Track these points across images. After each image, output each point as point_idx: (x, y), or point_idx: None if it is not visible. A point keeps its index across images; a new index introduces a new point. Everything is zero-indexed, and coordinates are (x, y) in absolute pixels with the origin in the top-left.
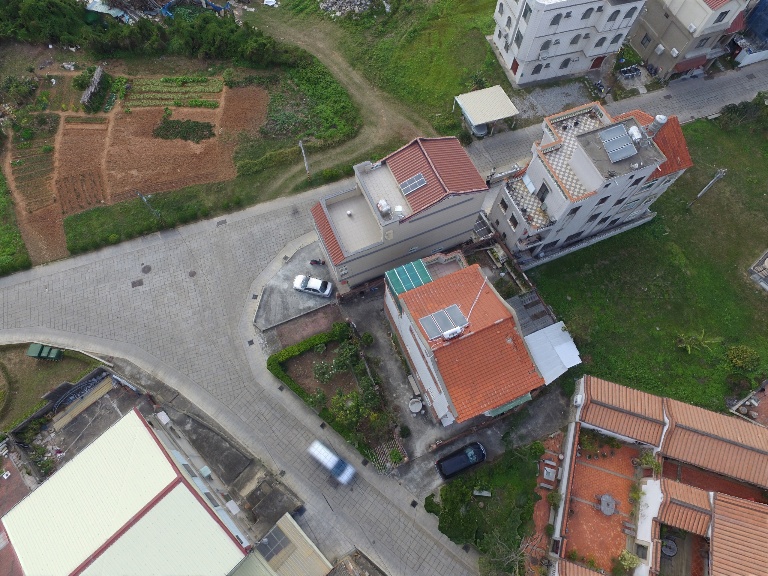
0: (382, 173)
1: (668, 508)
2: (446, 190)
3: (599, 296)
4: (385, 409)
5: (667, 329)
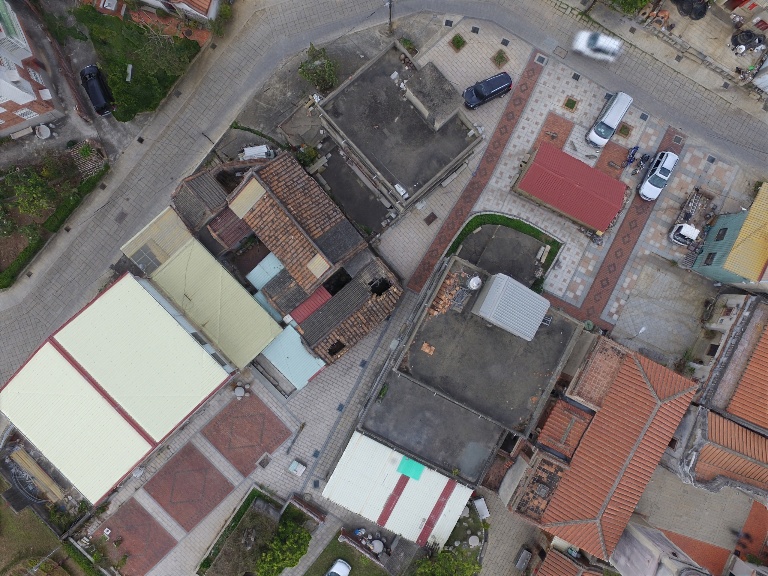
0: None
1: None
2: None
3: None
4: None
5: None
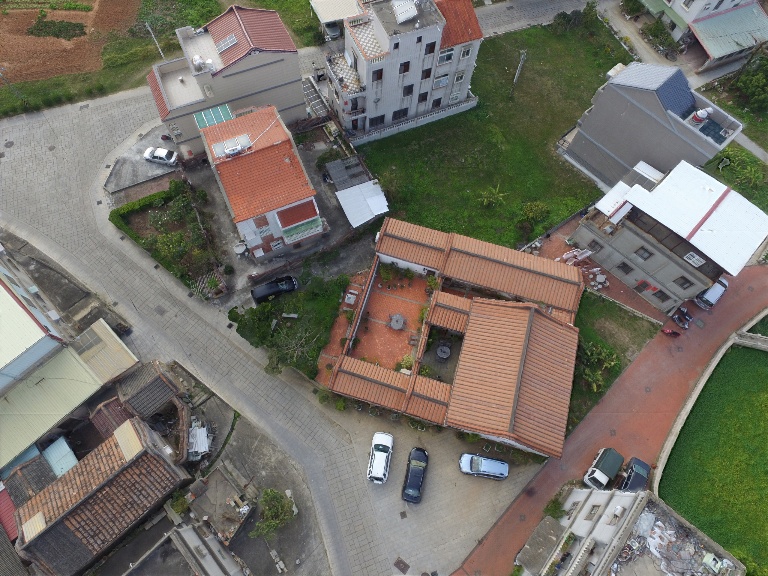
0: (204, 38)
1: (434, 311)
2: (251, 45)
3: (420, 166)
4: (211, 250)
5: (476, 191)
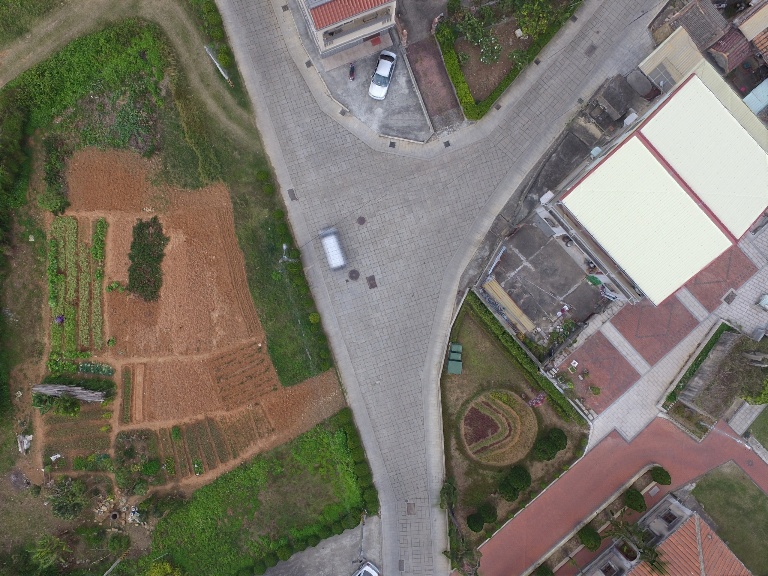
0: None
1: None
2: None
3: None
4: None
5: None
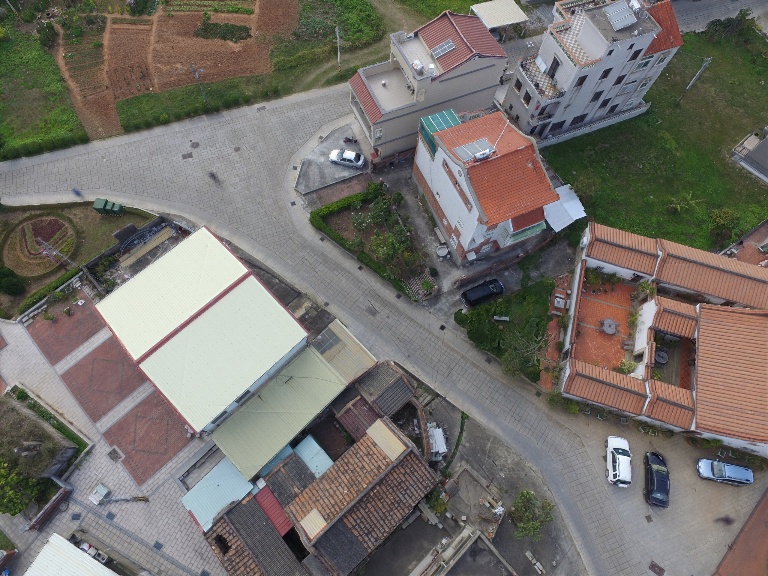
0: (414, 43)
1: (661, 316)
2: (473, 51)
3: (600, 171)
4: (416, 252)
5: (660, 197)
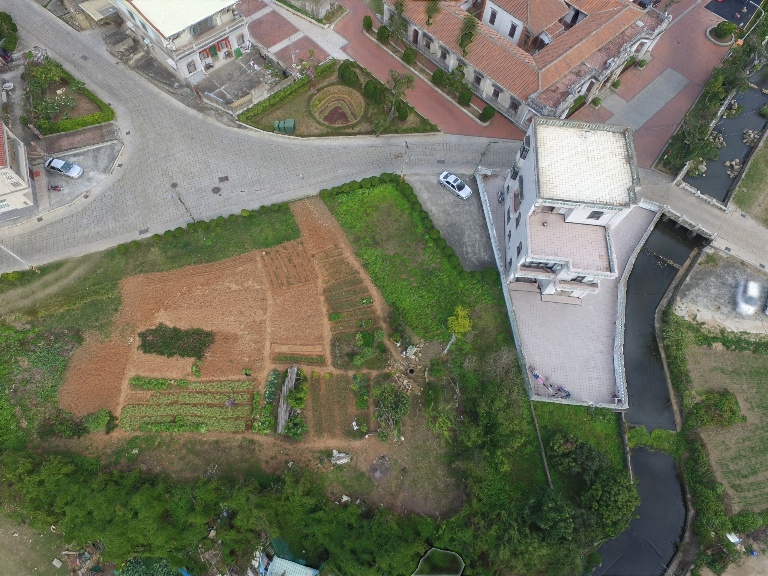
0: None
1: None
2: None
3: None
4: None
5: None
